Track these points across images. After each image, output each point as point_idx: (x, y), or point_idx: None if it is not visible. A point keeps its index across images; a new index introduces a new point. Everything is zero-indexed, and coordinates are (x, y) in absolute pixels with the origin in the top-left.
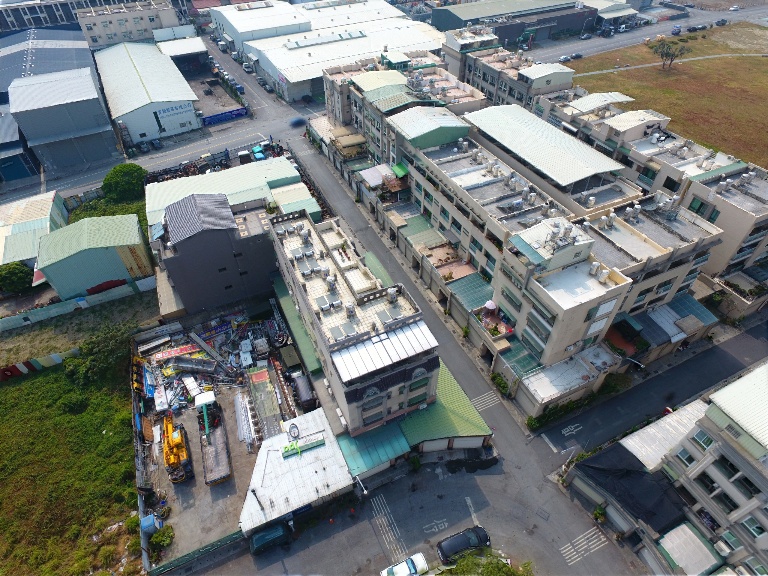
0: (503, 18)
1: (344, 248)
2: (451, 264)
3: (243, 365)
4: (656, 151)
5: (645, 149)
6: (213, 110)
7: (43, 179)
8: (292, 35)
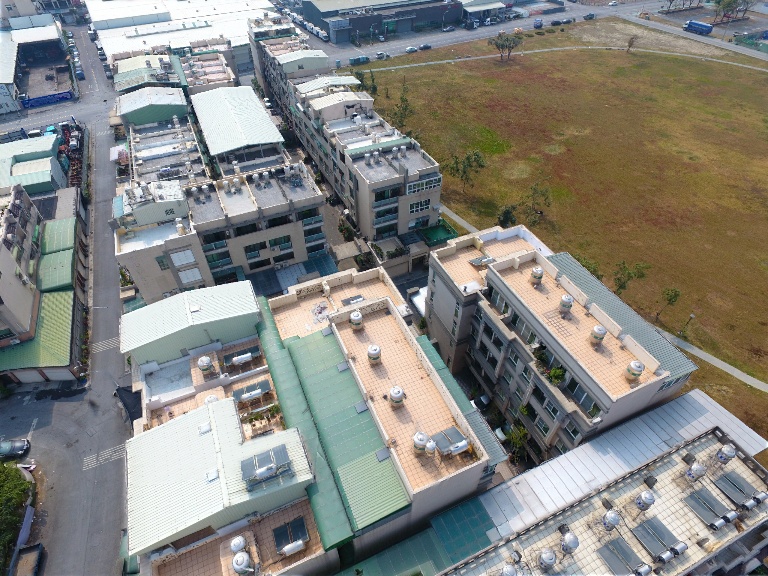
0: (363, 10)
1: None
2: None
3: None
4: (347, 128)
5: (343, 127)
6: (43, 94)
7: None
8: (148, 24)
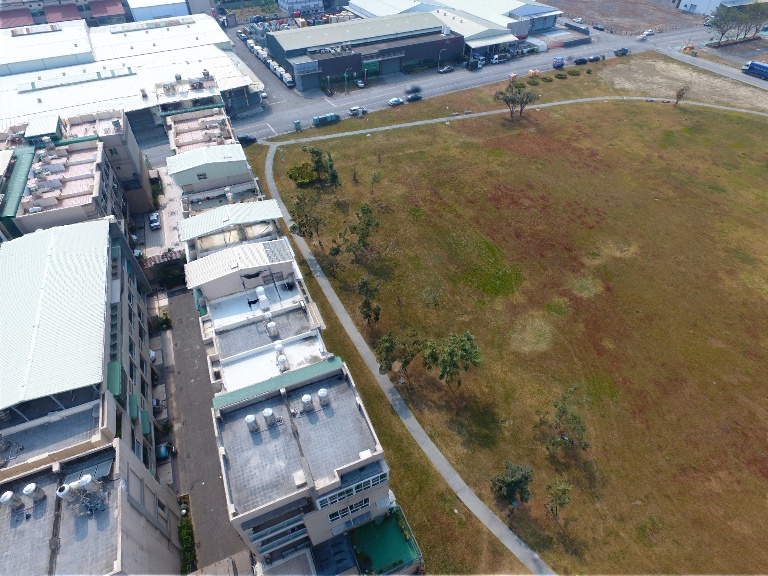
0: (338, 47)
1: None
2: None
3: None
4: (241, 321)
5: (238, 312)
6: None
7: None
8: (62, 69)
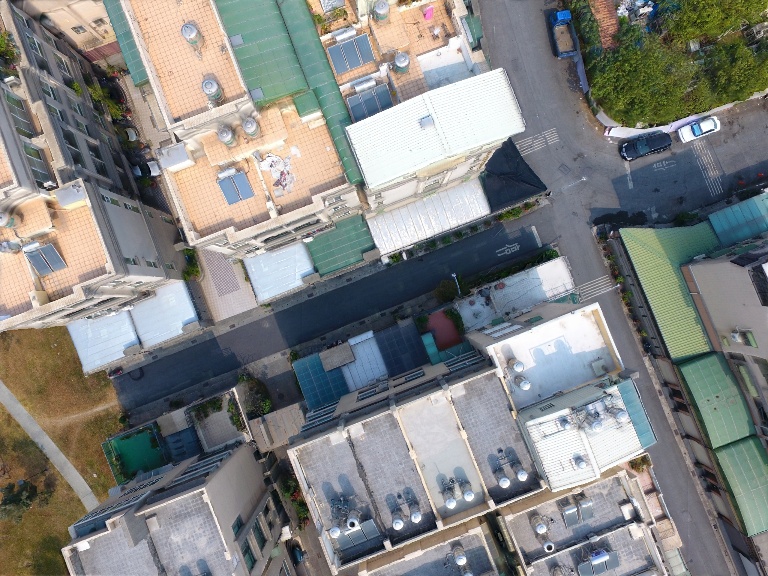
0: None
1: None
2: None
3: None
4: None
5: None
6: None
7: None
8: None
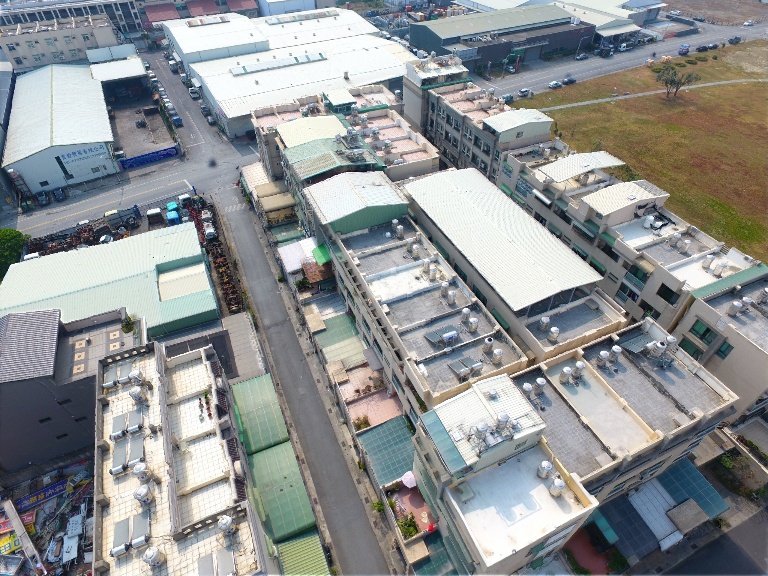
0: (488, 36)
1: (206, 398)
2: (371, 396)
3: (63, 560)
4: (649, 242)
5: (635, 236)
6: (140, 148)
7: None
8: (246, 56)
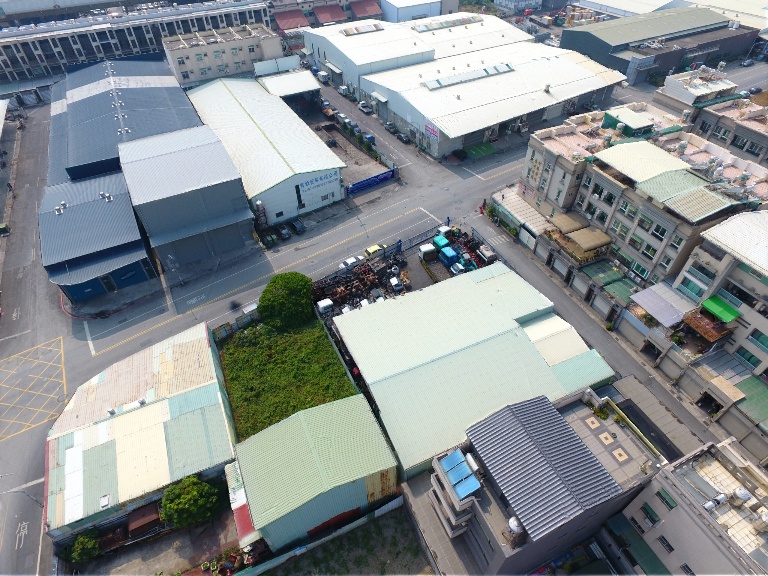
0: (656, 42)
1: None
2: None
3: None
4: None
5: None
6: (348, 171)
7: (165, 285)
8: (416, 67)
